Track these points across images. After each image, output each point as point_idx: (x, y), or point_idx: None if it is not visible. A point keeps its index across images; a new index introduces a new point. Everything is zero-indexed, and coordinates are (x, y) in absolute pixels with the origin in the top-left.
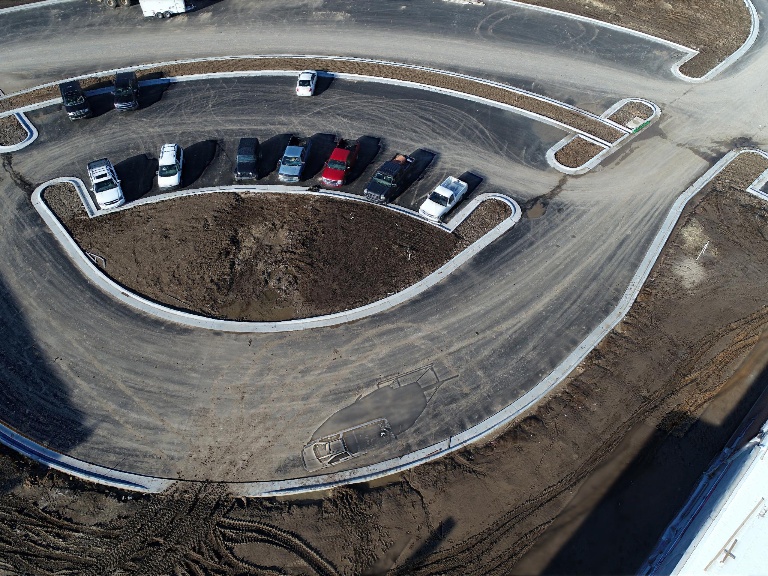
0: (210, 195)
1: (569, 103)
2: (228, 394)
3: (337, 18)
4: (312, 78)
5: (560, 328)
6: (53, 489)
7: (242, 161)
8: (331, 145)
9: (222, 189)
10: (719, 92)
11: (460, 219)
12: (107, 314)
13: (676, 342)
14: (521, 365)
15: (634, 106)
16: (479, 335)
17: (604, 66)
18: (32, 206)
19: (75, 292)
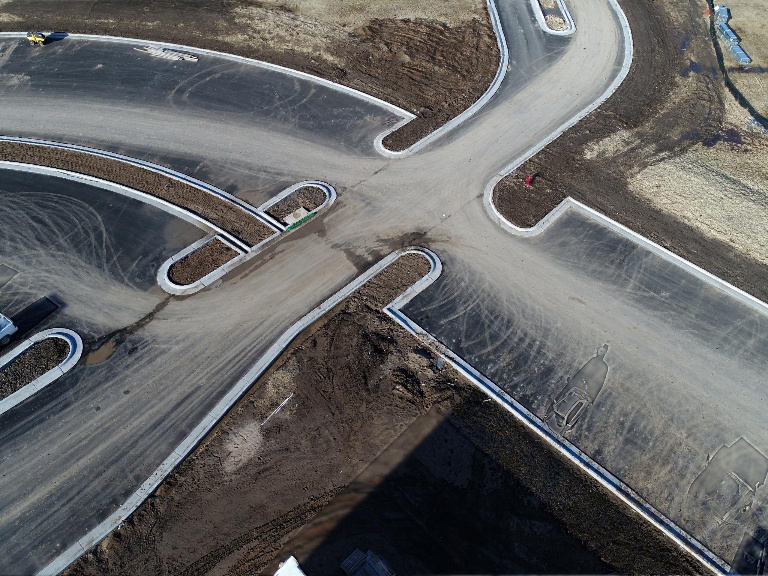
0: None
1: (229, 191)
2: None
3: (11, 82)
4: None
5: (24, 547)
6: None
7: None
8: None
9: None
10: (416, 170)
11: None
12: None
13: (163, 567)
14: None
15: (306, 192)
16: None
17: (297, 138)
18: None
19: None
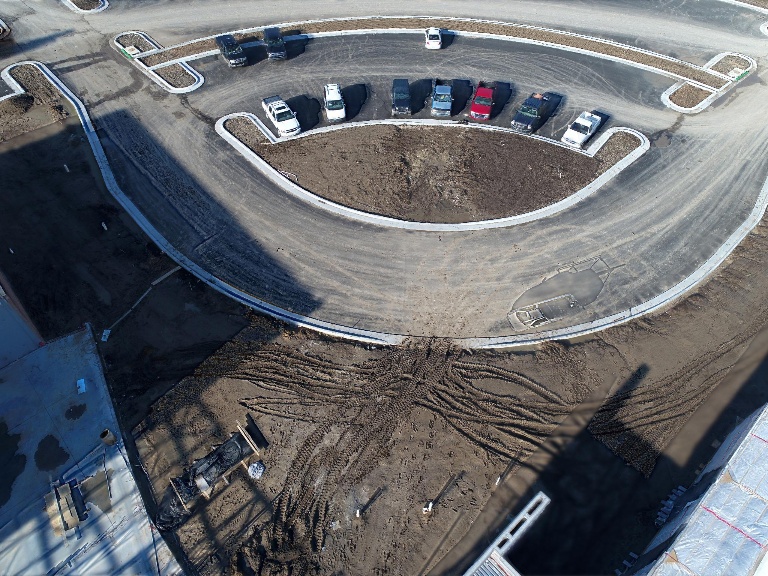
0: (373, 126)
1: (672, 56)
2: (432, 276)
3: None
4: (439, 33)
5: (705, 230)
6: (309, 340)
7: (398, 98)
8: (468, 88)
9: (382, 122)
10: None
11: (597, 147)
12: (311, 216)
13: None
14: (677, 257)
15: (732, 59)
16: (635, 235)
17: (698, 26)
18: (218, 135)
19: (278, 200)
